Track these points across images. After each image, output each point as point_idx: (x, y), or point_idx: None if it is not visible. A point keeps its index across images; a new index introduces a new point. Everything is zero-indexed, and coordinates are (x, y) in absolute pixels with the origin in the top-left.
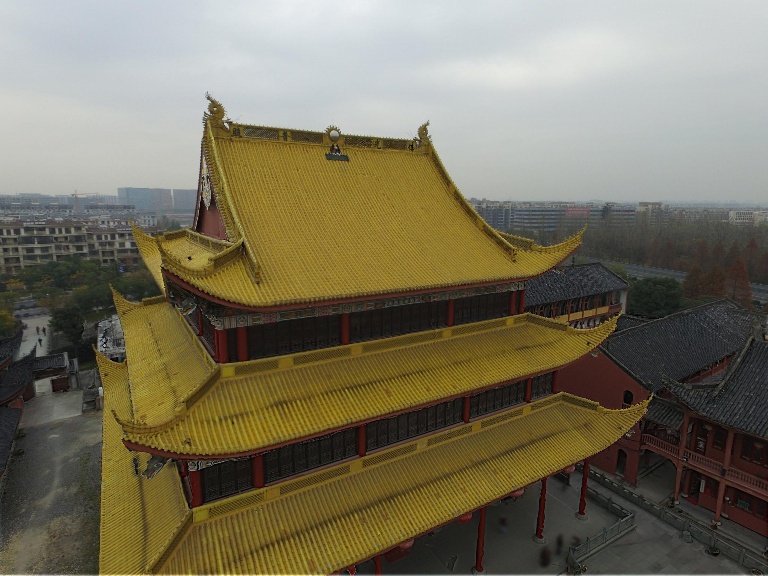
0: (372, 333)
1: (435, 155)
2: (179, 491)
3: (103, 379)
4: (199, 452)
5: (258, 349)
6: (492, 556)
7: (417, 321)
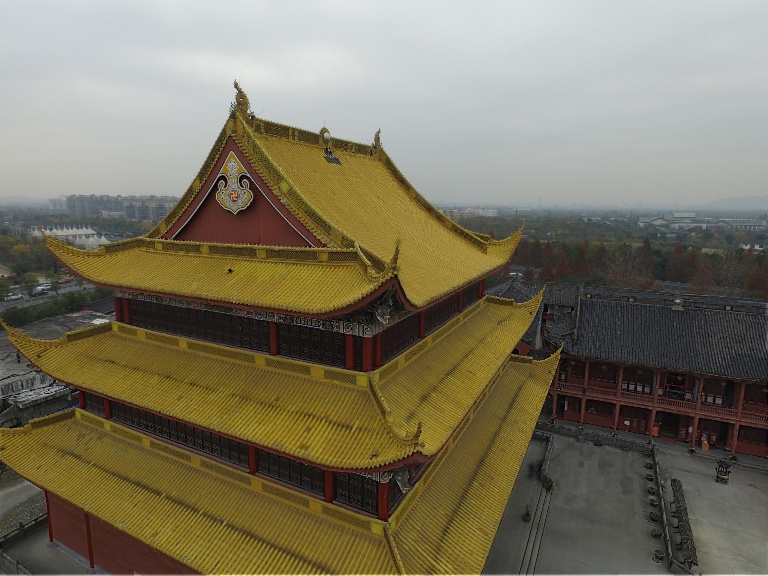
0: (431, 325)
1: (390, 161)
2: (327, 520)
3: (1, 455)
4: (433, 452)
5: (383, 353)
6: None
7: (447, 310)
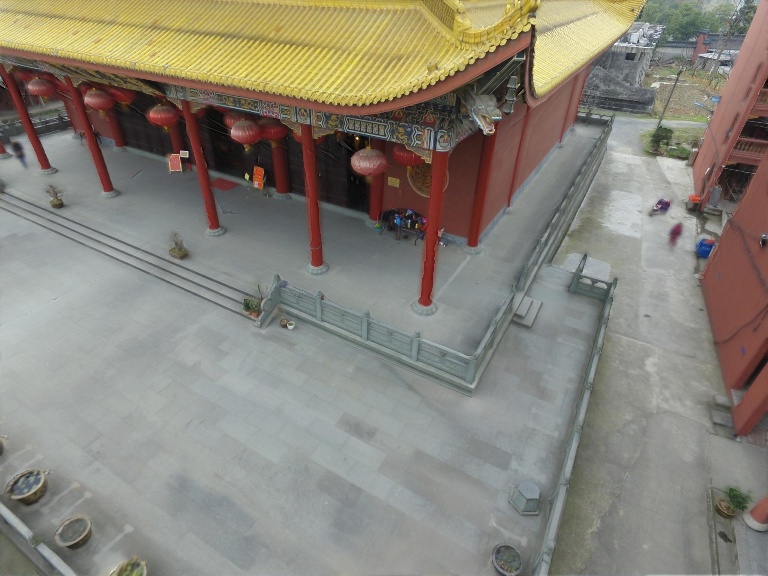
0: None
1: None
2: None
3: None
4: None
5: None
6: (252, 236)
7: None
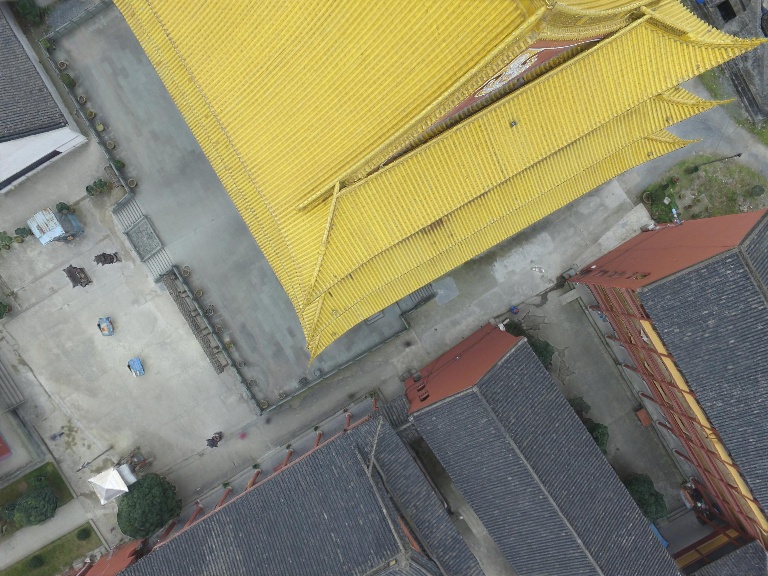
0: None
1: None
2: None
3: None
4: None
5: None
6: None
7: None
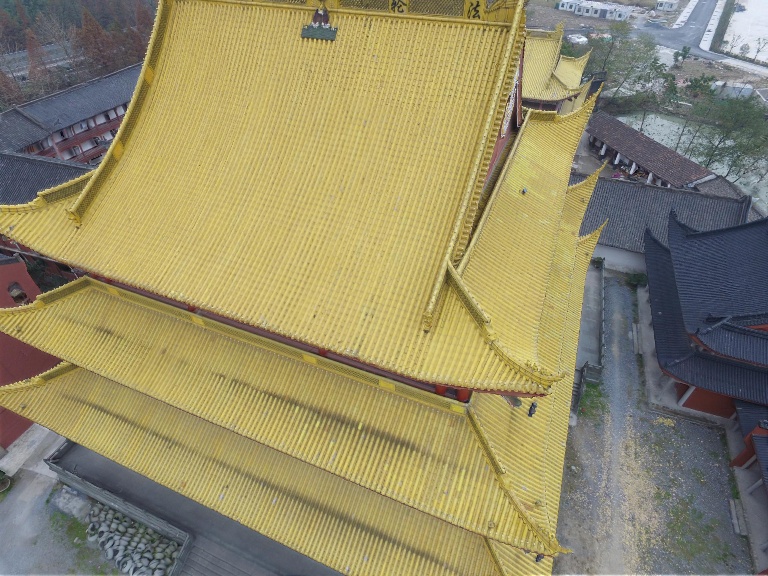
0: None
1: None
2: None
3: None
4: None
5: None
6: None
7: None
